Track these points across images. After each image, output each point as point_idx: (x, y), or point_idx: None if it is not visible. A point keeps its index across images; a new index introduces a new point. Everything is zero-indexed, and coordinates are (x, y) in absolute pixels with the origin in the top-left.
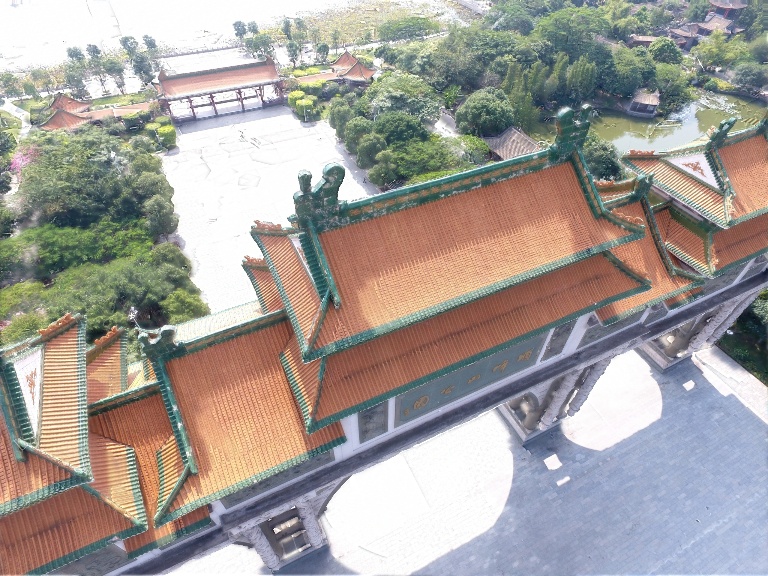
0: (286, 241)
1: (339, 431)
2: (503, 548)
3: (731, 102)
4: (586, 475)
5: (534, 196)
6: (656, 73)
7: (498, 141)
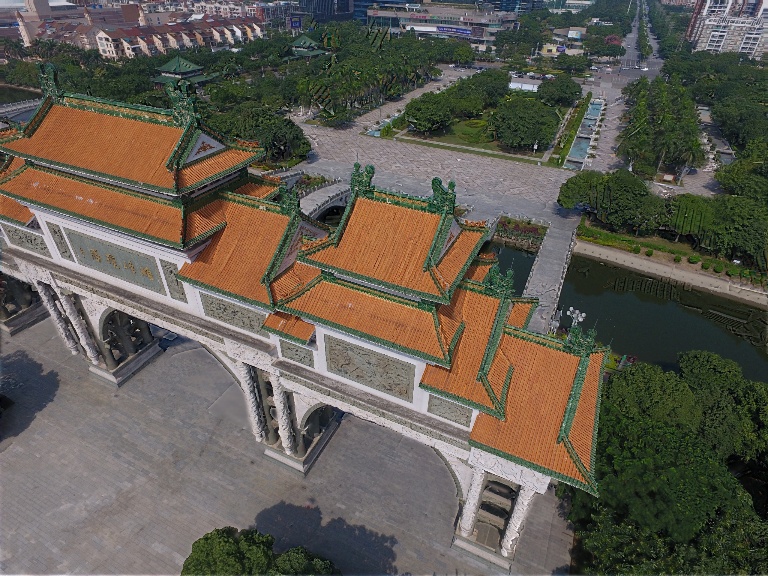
0: (183, 172)
1: None
2: None
3: None
4: None
5: None
6: None
7: None
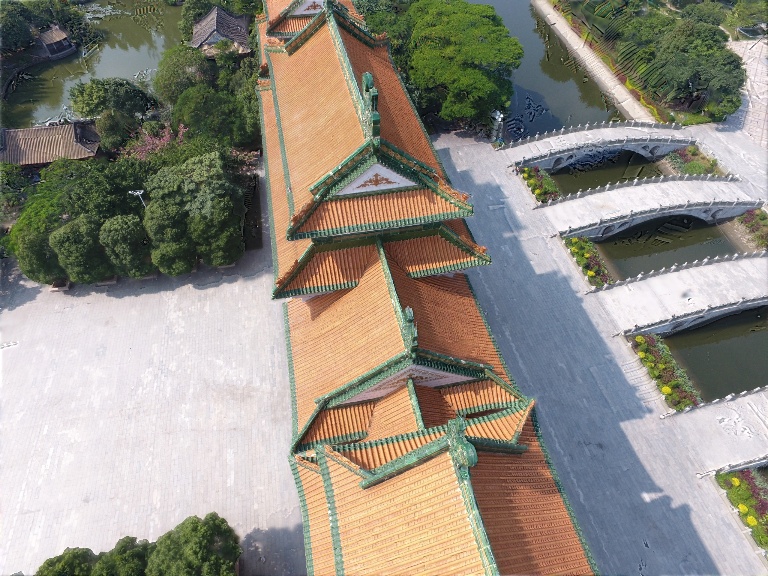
0: (326, 206)
1: (461, 275)
2: None
3: (105, 5)
4: None
5: (354, 54)
6: (29, 9)
7: (9, 153)
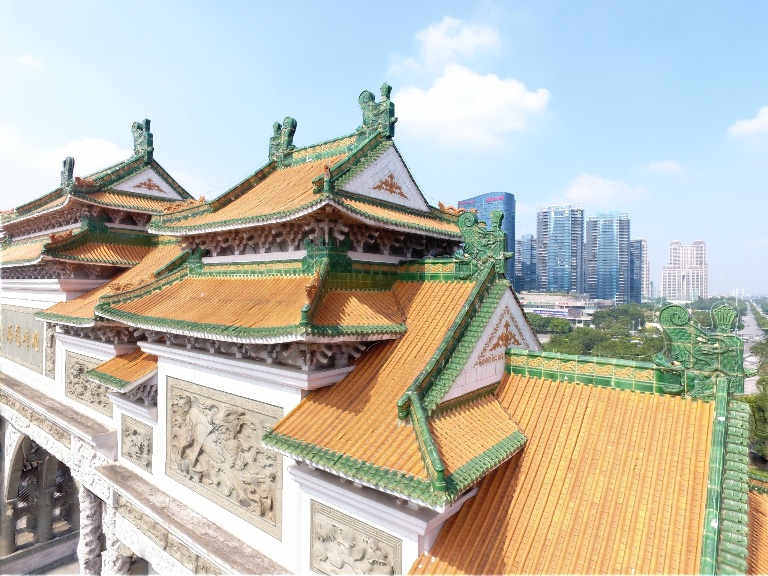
0: (105, 194)
1: None
2: None
3: None
4: None
5: None
6: None
7: None
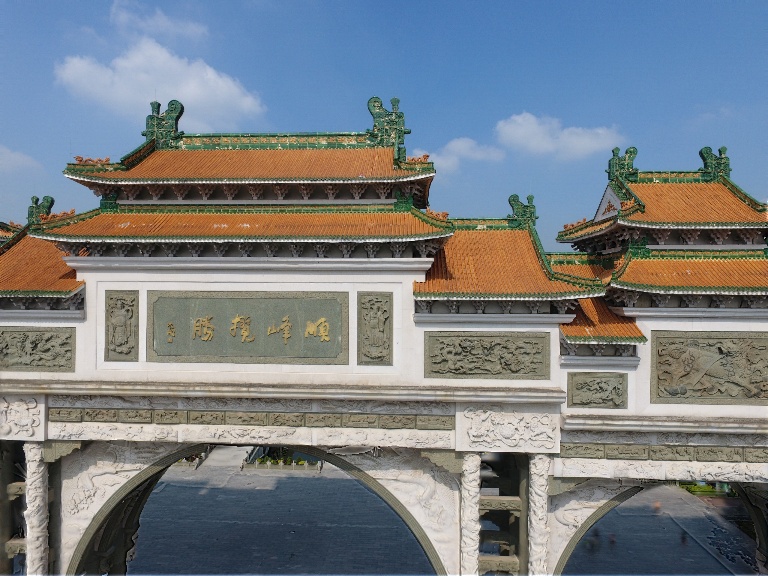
0: None
1: None
2: (272, 568)
3: None
4: (129, 575)
5: None
6: None
7: None
